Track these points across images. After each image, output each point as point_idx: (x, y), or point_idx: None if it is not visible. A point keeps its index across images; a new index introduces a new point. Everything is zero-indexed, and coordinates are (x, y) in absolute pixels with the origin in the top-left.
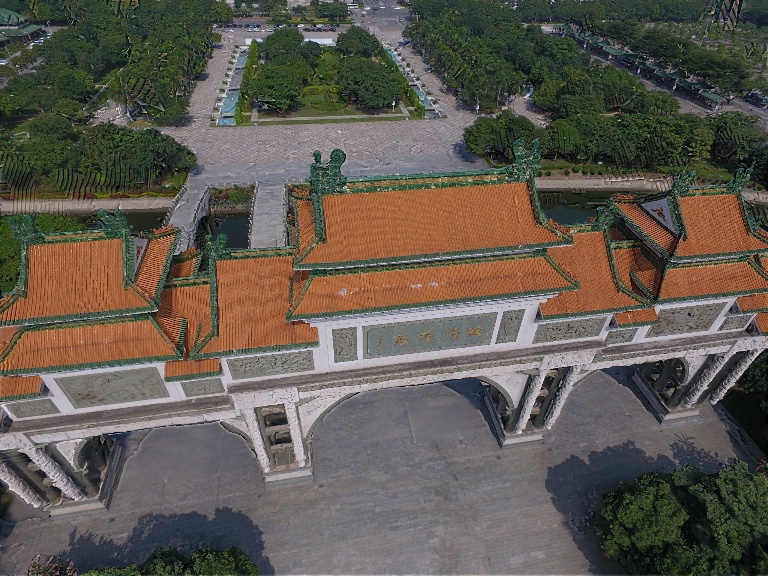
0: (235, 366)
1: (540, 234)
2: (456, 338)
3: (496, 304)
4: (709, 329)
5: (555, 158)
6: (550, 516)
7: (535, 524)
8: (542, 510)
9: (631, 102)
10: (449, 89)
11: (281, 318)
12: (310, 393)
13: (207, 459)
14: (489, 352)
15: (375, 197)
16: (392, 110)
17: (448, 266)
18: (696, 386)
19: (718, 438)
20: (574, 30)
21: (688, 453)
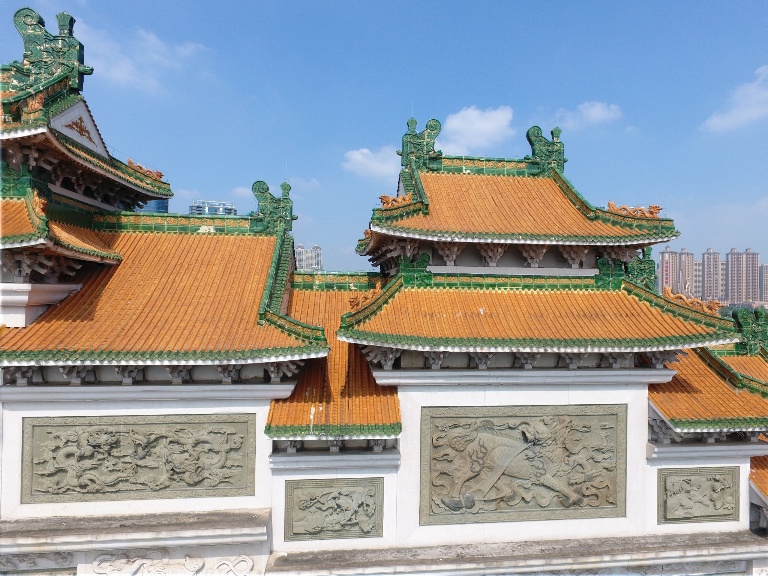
0: None
1: None
2: None
3: None
4: (626, 511)
5: None
6: None
7: None
8: None
9: None
10: None
11: None
12: None
13: None
14: None
15: None
16: None
17: None
18: None
19: None
20: None
21: None
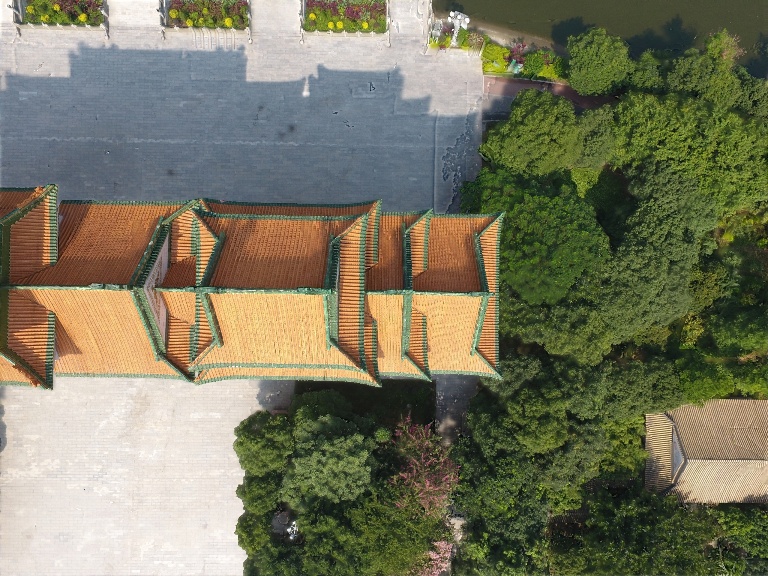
0: None
1: None
2: None
3: None
4: None
5: None
6: (240, 388)
7: (224, 392)
8: (235, 382)
9: None
10: None
11: None
12: None
13: None
14: None
15: None
16: None
17: None
18: None
19: None
20: None
21: None
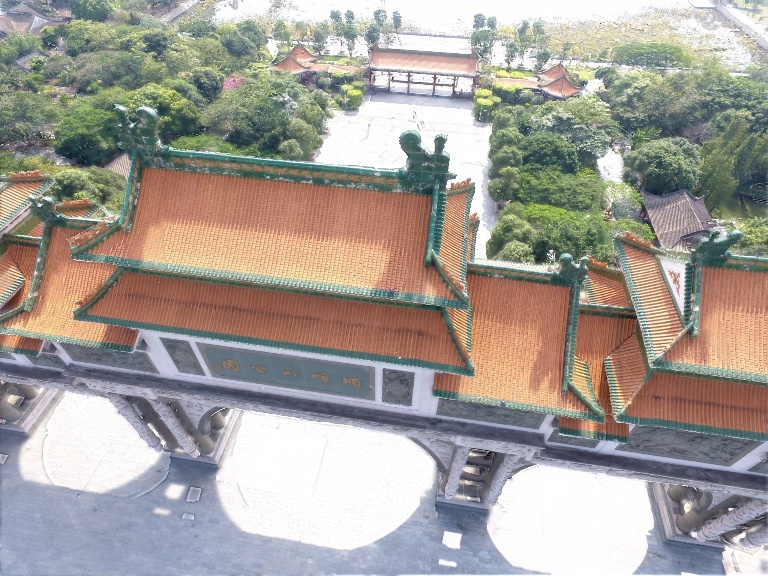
0: None
1: None
2: None
3: None
4: None
5: None
6: None
7: None
8: None
9: None
10: None
11: None
12: None
13: (557, 494)
14: None
15: None
16: None
17: None
18: None
19: None
20: None
21: None
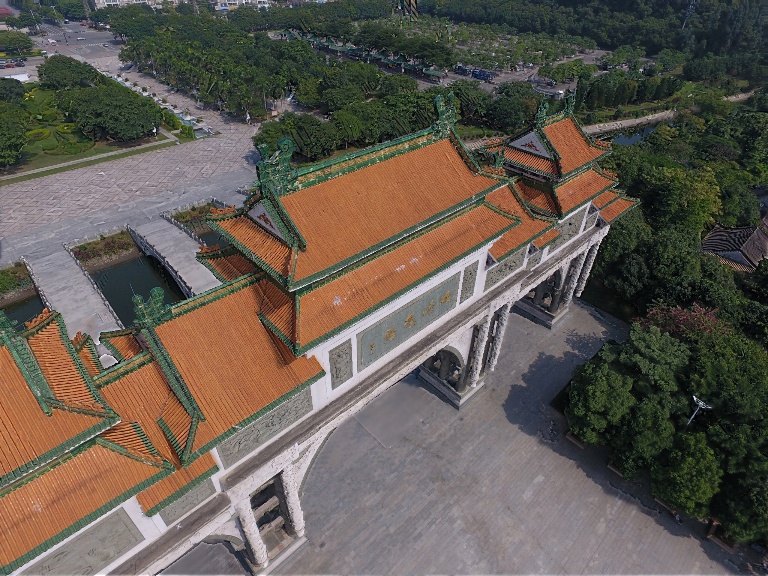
0: (226, 450)
1: (480, 182)
2: (432, 312)
3: (460, 263)
4: (579, 233)
5: (346, 147)
6: (527, 443)
7: (521, 456)
8: (519, 442)
9: (382, 87)
10: (207, 105)
11: (269, 363)
12: (309, 440)
13: None
14: (455, 315)
15: (329, 186)
16: (154, 138)
17: (417, 238)
18: (569, 286)
19: (588, 321)
20: (296, 34)
21: (579, 342)
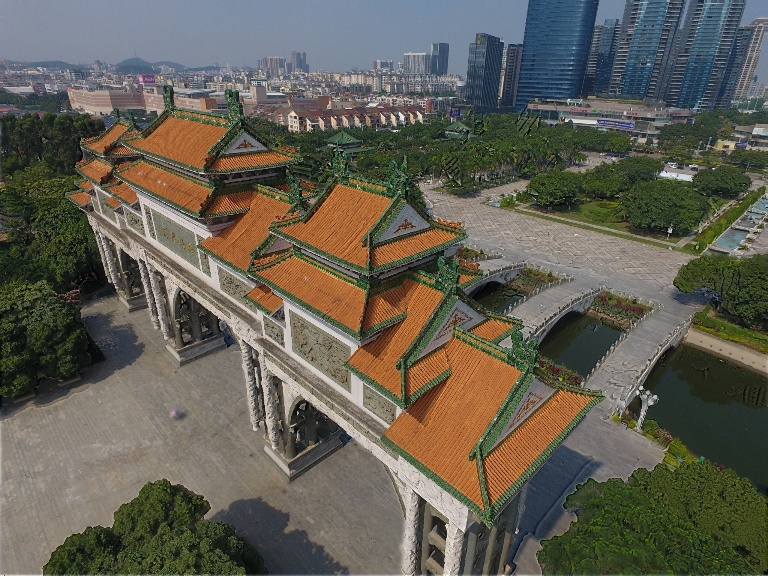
0: None
1: None
2: None
3: None
4: (352, 392)
5: None
6: None
7: None
8: None
9: None
10: None
11: None
12: None
13: None
14: None
15: (181, 122)
16: (666, 238)
17: None
18: None
19: None
20: None
21: None
